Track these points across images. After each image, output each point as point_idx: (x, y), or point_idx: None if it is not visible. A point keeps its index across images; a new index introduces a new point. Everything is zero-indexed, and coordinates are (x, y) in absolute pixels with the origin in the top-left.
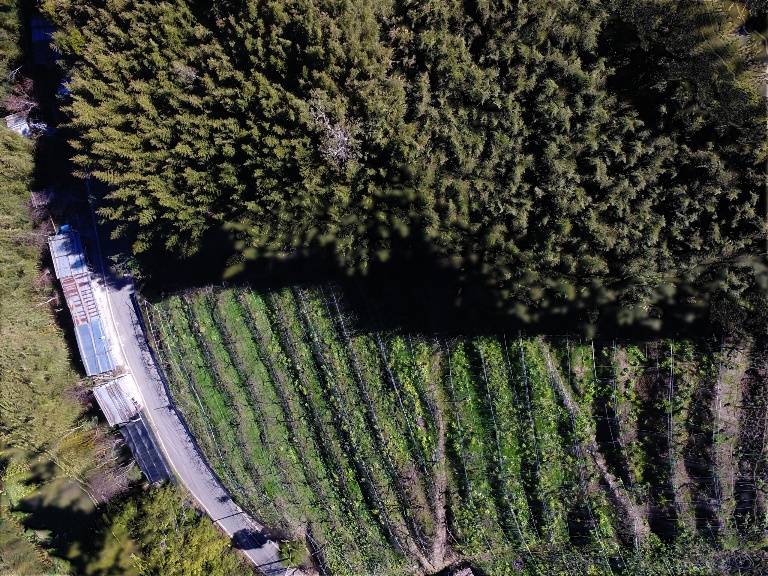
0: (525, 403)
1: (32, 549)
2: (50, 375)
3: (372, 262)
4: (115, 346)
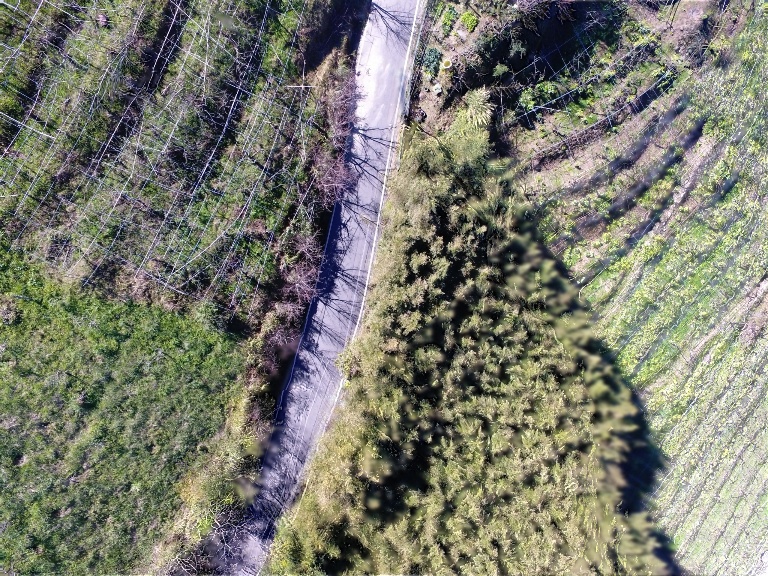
0: None
1: None
2: None
3: (618, 500)
4: None
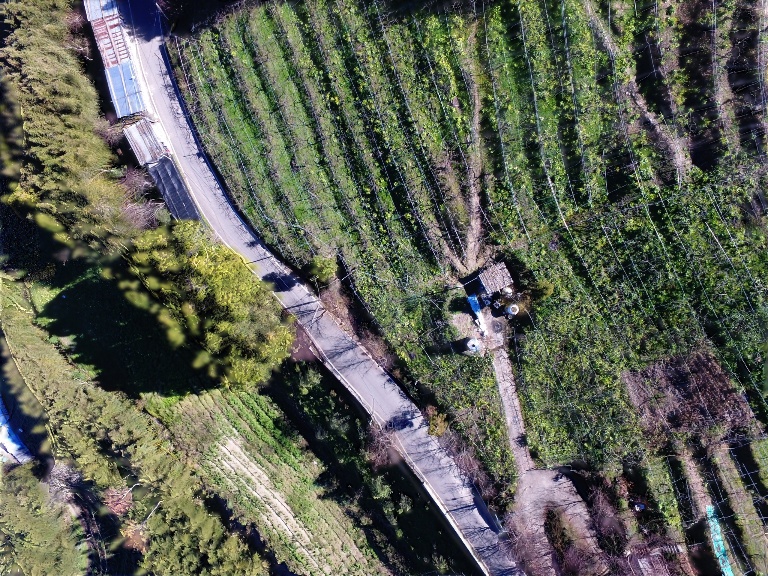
0: (563, 54)
1: (56, 353)
2: (81, 109)
3: None
4: (145, 94)
